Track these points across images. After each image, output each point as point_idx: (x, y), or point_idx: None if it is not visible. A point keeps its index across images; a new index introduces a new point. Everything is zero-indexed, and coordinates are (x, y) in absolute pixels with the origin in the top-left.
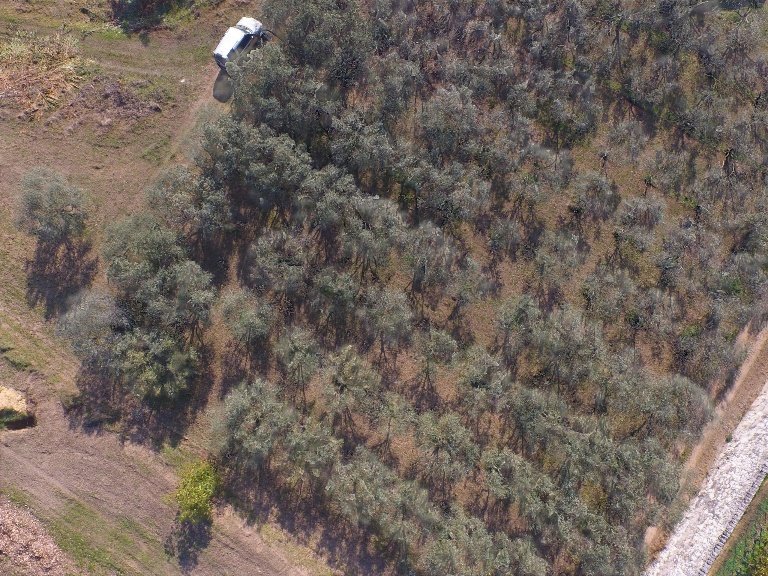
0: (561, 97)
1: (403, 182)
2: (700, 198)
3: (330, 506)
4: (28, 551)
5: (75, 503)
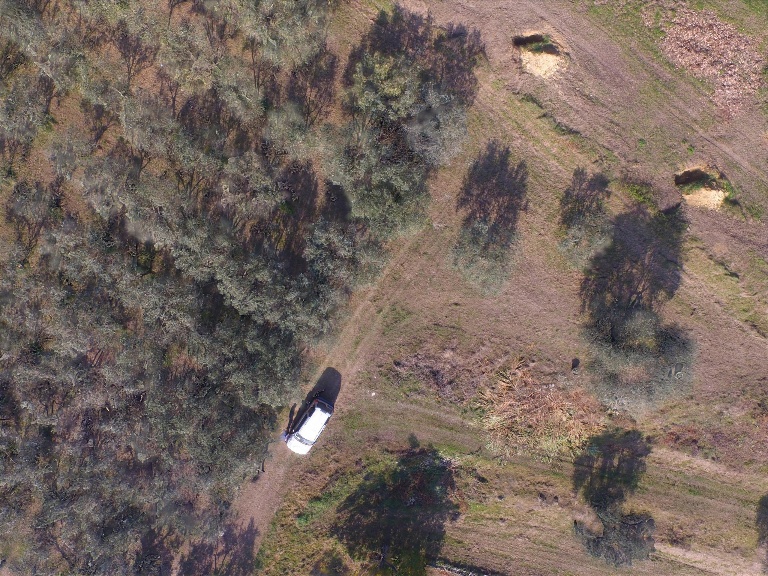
0: None
1: (149, 273)
2: None
3: None
4: None
5: None
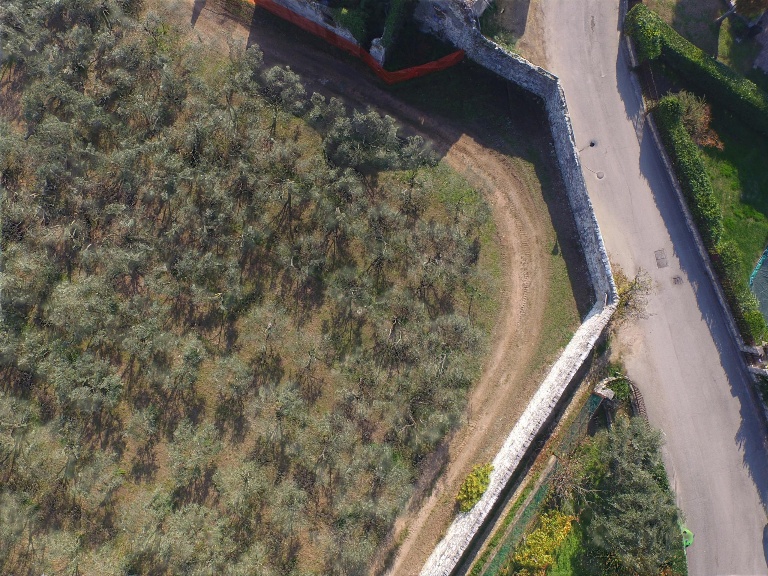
0: None
1: None
2: (365, 369)
3: None
4: None
5: None
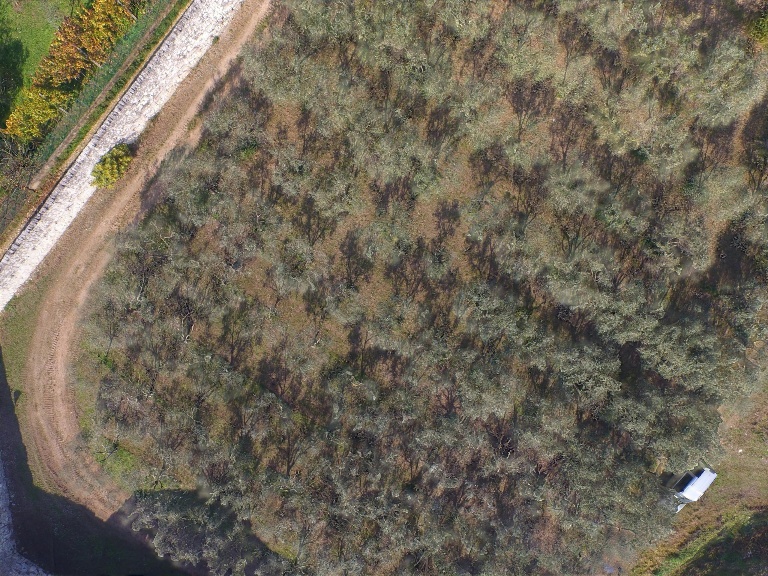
0: (353, 409)
1: None
2: (221, 293)
3: None
4: None
5: None
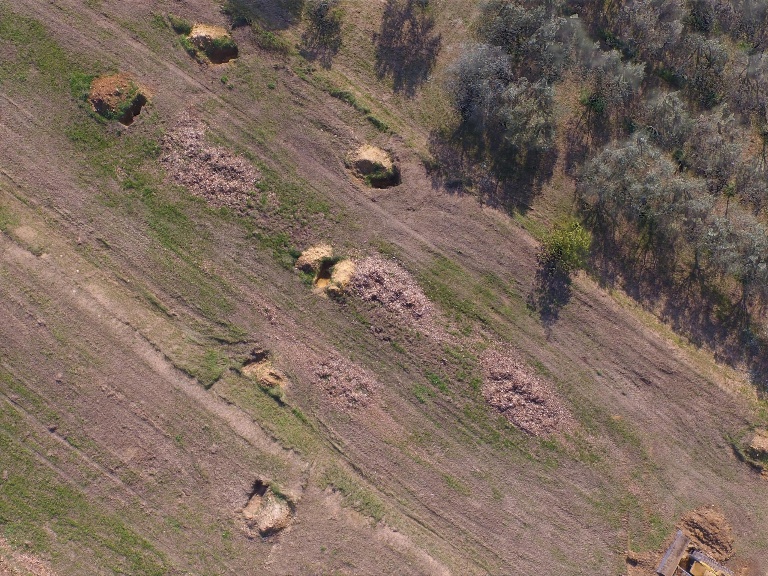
0: None
1: None
2: None
3: (673, 276)
4: (399, 299)
5: (441, 257)
